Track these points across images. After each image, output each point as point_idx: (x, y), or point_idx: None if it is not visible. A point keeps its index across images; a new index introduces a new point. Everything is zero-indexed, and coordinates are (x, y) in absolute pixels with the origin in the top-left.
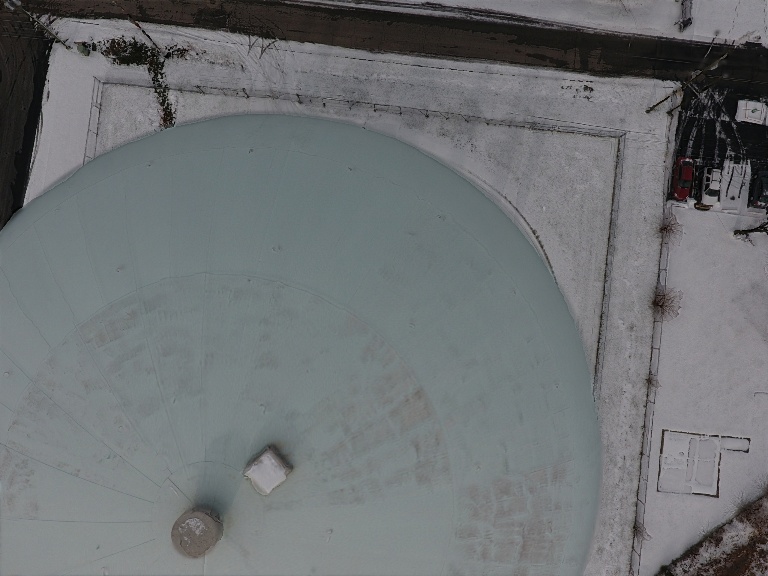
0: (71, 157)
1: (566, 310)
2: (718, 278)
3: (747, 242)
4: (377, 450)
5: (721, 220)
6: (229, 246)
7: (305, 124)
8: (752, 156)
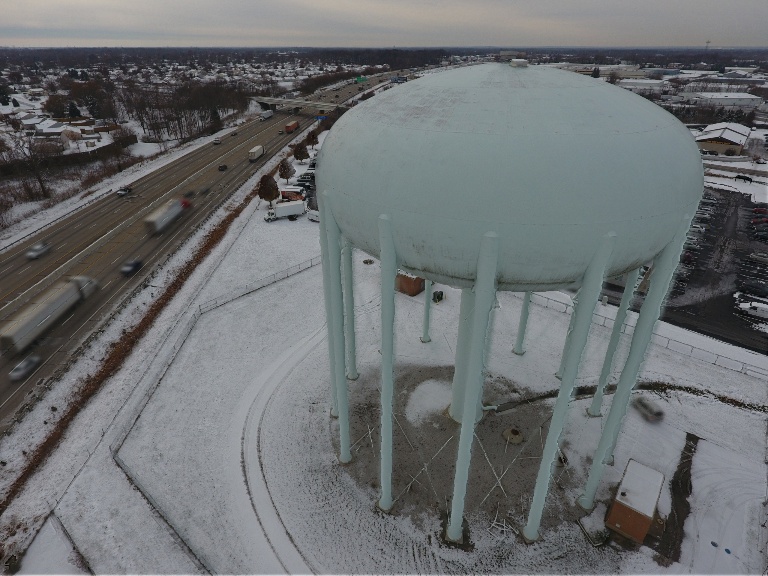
0: None
1: (513, 214)
2: None
3: None
4: (508, 76)
5: None
6: (619, 90)
7: (692, 149)
8: None
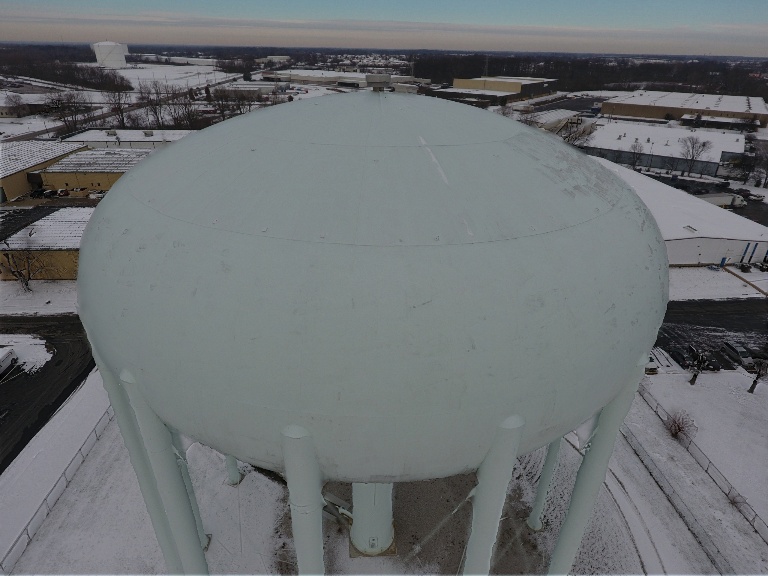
0: (100, 403)
1: None
2: (708, 412)
3: (705, 388)
4: None
5: (672, 378)
6: None
7: None
8: (658, 345)
